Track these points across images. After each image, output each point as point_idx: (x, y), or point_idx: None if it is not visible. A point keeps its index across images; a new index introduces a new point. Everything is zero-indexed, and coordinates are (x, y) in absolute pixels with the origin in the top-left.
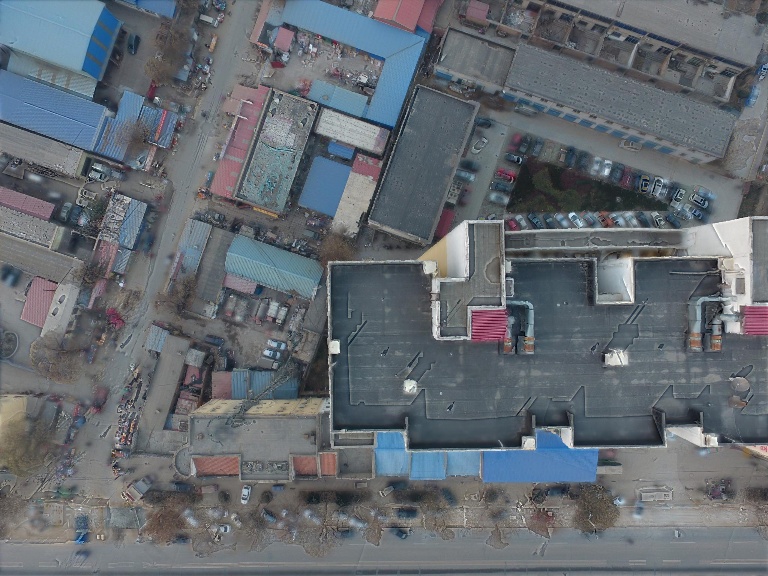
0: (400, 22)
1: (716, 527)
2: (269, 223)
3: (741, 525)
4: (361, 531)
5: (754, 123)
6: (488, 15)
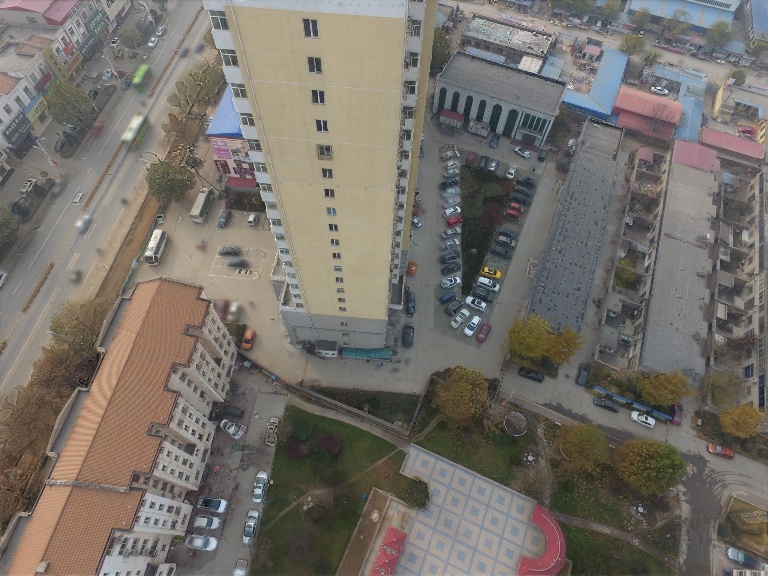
0: (619, 96)
1: (89, 309)
2: (455, 40)
3: (77, 337)
4: (212, 62)
5: (568, 333)
6: (643, 165)
